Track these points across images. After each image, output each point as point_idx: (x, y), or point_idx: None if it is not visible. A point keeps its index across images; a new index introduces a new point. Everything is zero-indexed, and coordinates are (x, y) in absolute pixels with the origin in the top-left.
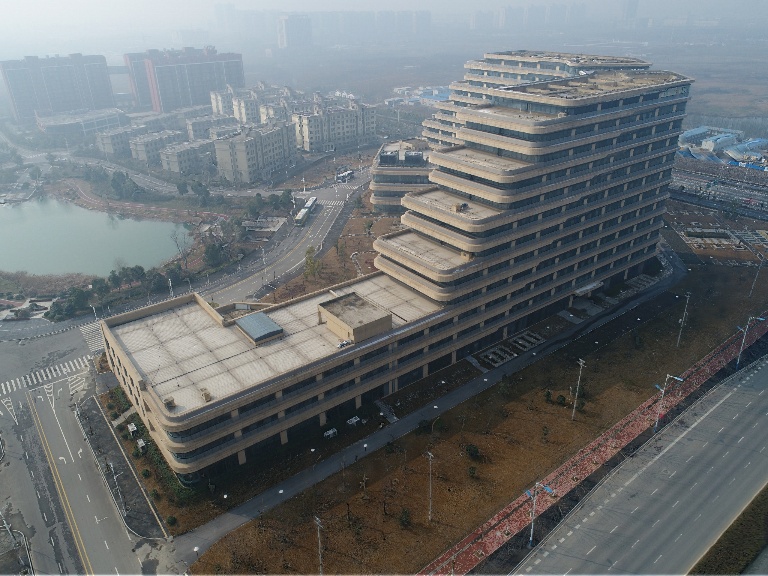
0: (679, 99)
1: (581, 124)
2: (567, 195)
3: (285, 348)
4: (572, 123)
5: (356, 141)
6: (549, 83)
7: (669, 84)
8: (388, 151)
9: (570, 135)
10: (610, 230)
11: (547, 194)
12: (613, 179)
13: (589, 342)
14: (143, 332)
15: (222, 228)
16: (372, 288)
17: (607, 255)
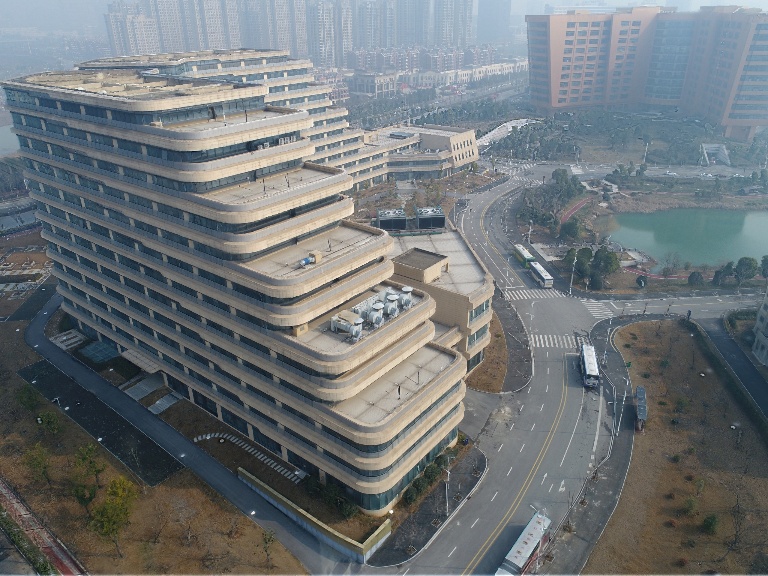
0: None
1: None
2: None
3: (385, 135)
4: None
5: None
6: None
7: None
8: (434, 213)
9: None
10: None
11: None
12: None
13: None
14: (453, 134)
15: None
16: (361, 149)
17: None
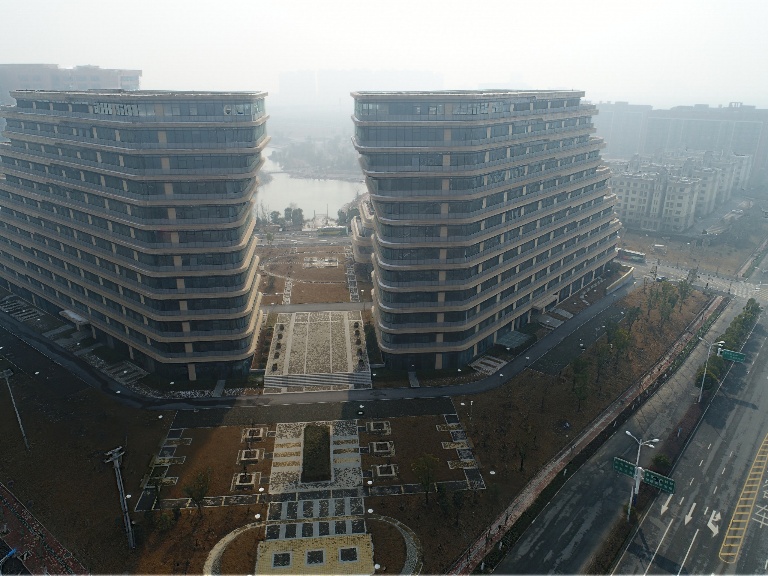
0: (111, 121)
1: (19, 117)
2: (37, 191)
3: None
4: (12, 114)
5: (640, 221)
6: (154, 92)
7: (89, 95)
8: None
9: (22, 127)
10: (88, 266)
11: (23, 180)
12: (73, 199)
13: (0, 338)
14: None
15: (286, 213)
16: None
17: (98, 299)
